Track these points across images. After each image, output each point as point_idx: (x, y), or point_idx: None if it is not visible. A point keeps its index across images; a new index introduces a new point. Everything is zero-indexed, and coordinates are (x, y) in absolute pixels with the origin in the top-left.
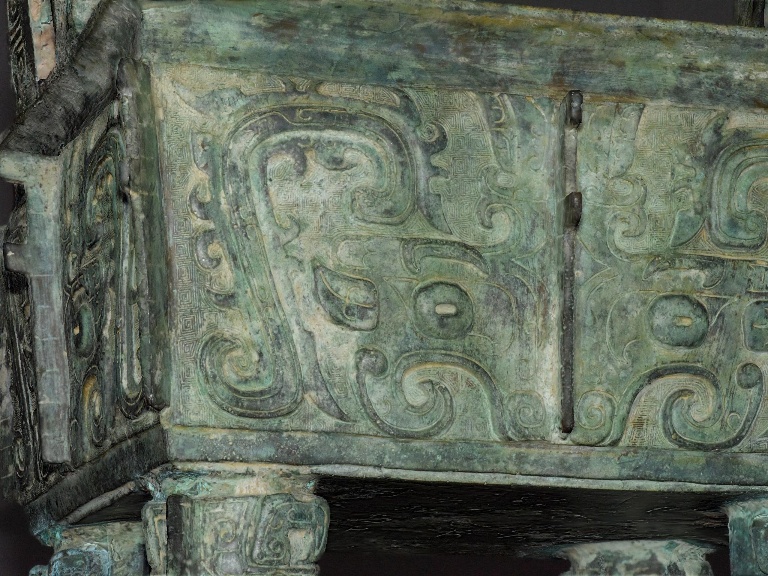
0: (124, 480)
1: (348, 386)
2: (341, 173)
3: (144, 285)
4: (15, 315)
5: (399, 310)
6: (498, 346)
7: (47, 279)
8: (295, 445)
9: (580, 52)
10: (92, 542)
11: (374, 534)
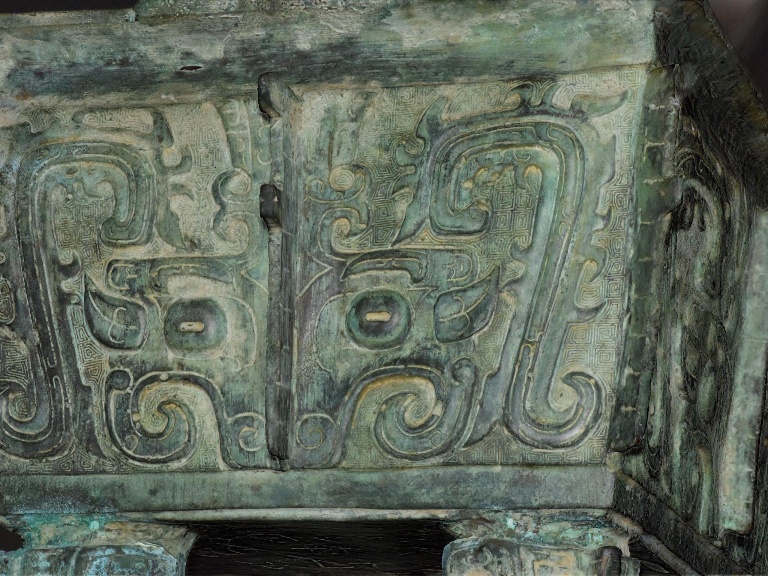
0: (444, 505)
1: (673, 455)
2: (699, 233)
3: (658, 315)
4: (52, 242)
5: (698, 385)
6: (712, 437)
7: (290, 238)
8: (648, 509)
9: (752, 159)
10: (145, 542)
11: (253, 572)
